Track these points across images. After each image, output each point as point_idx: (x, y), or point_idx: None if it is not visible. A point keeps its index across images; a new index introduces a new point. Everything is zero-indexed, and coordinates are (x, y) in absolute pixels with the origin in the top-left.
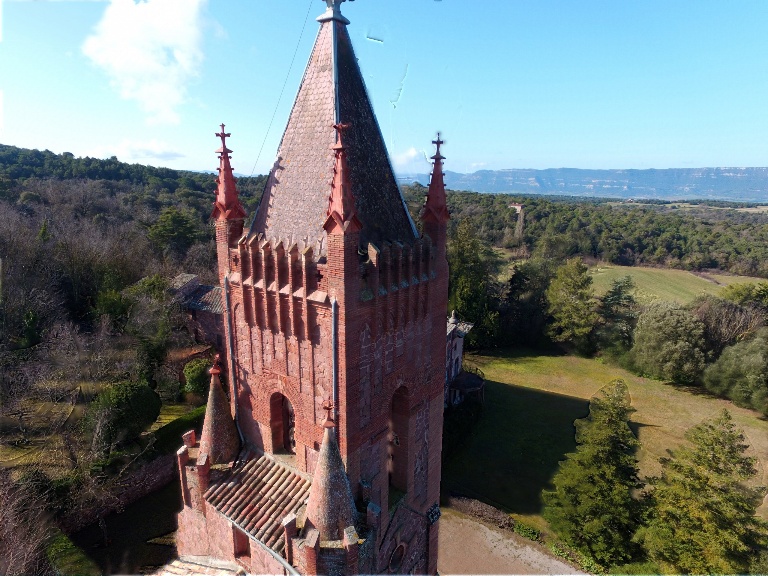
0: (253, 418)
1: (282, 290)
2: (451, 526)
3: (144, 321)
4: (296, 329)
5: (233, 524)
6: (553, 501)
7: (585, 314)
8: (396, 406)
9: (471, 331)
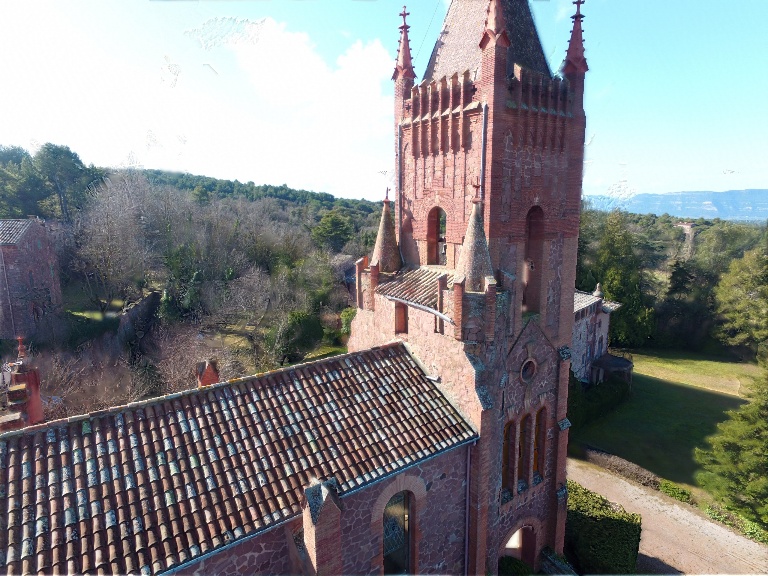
0: (413, 238)
1: (444, 113)
2: (587, 475)
3: (312, 273)
4: (453, 142)
5: (396, 304)
6: (708, 458)
7: (767, 313)
8: (532, 233)
9: (618, 310)
